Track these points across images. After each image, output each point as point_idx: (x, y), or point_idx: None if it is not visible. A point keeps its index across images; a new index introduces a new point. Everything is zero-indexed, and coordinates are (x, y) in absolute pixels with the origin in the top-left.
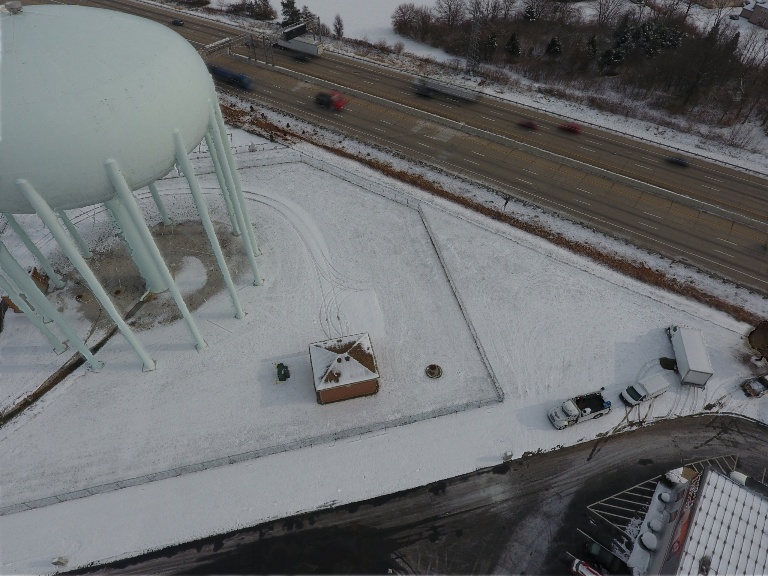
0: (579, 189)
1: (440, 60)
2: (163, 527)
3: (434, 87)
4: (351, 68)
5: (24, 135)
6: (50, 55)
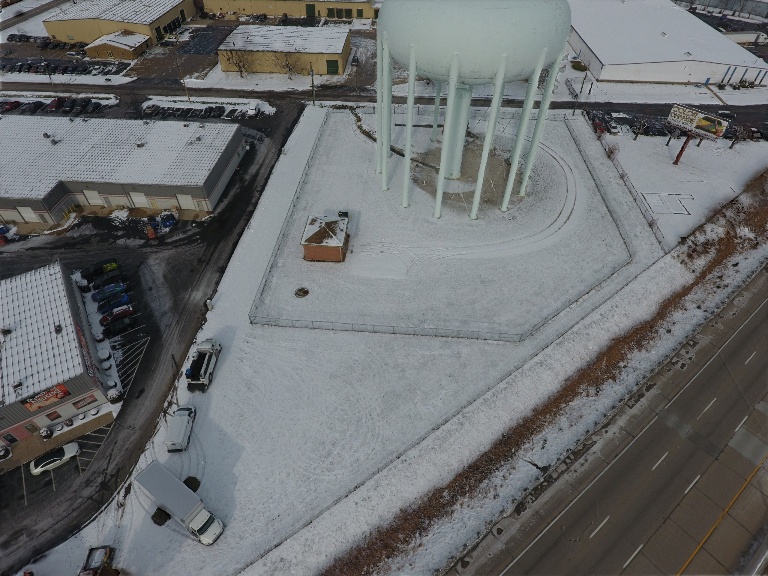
0: None
1: None
2: (280, 177)
3: None
4: None
5: None
6: None
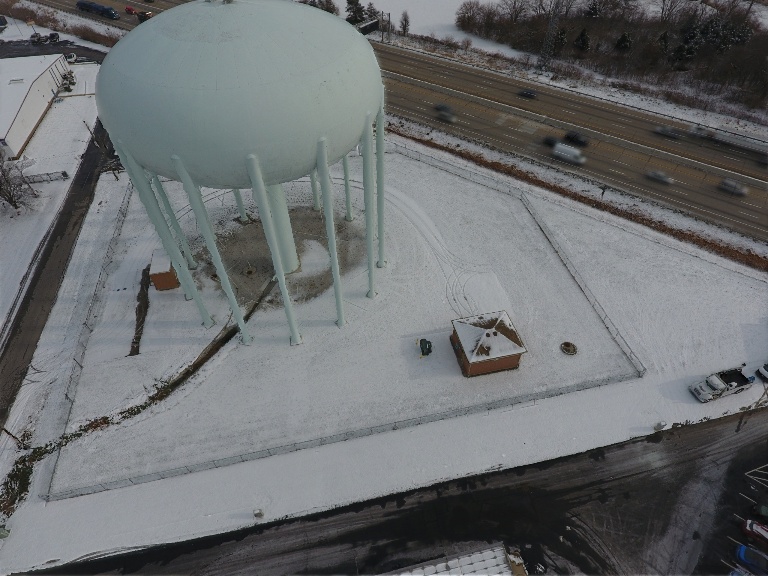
0: (673, 179)
1: (510, 55)
2: (345, 485)
3: (509, 81)
4: (423, 63)
5: (261, 113)
6: (273, 40)
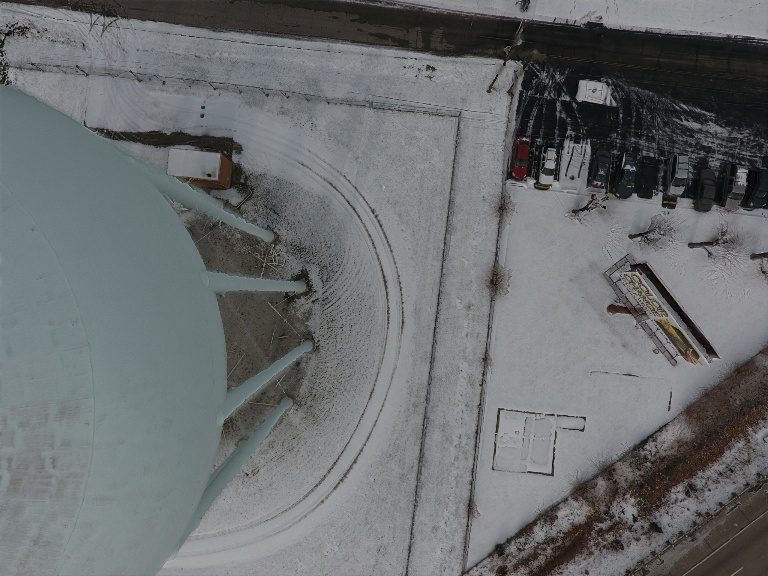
0: None
1: None
2: None
3: None
4: None
5: None
6: None
